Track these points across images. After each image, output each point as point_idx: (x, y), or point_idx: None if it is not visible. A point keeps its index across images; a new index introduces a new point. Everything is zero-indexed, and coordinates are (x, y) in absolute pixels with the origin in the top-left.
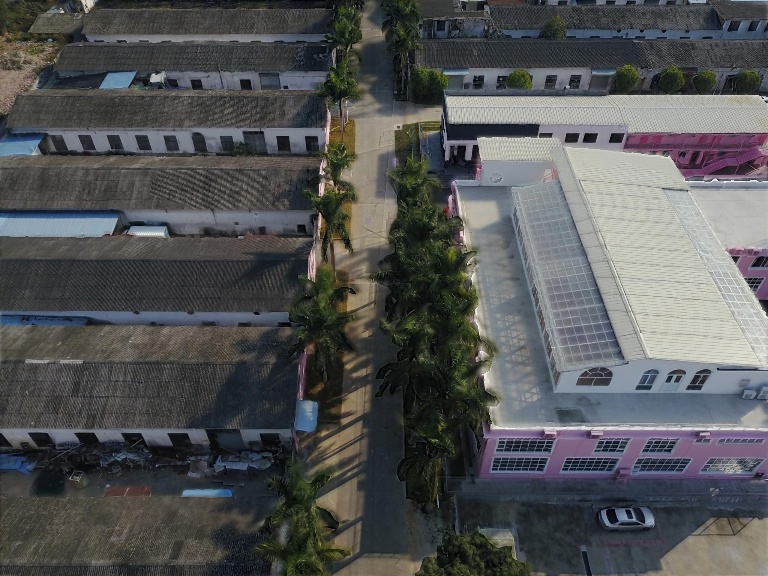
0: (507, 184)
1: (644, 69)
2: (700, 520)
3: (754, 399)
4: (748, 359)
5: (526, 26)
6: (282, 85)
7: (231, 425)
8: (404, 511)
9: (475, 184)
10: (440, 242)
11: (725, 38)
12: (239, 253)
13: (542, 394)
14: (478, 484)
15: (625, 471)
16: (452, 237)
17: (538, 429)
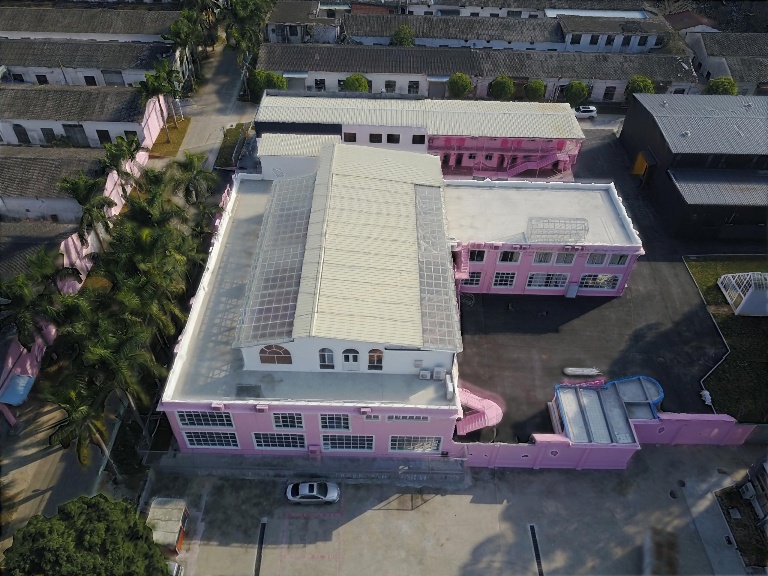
0: None
1: None
2: (385, 496)
3: (430, 379)
4: (412, 340)
5: (376, 34)
6: (126, 83)
7: None
8: (96, 482)
9: (258, 178)
10: (190, 229)
11: None
12: None
13: (231, 371)
14: (178, 458)
15: (314, 447)
16: (206, 225)
17: (207, 402)
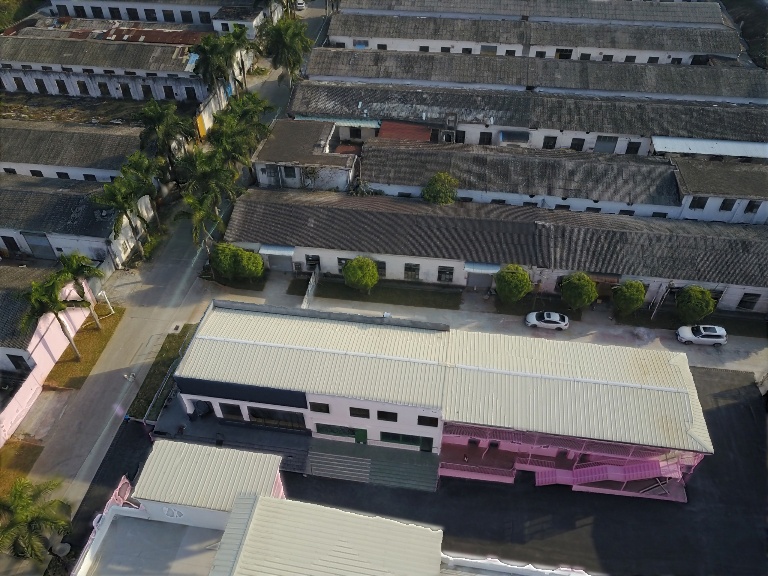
0: (190, 523)
1: (542, 268)
2: None
3: None
4: None
5: (403, 180)
6: (54, 246)
7: None
8: None
9: (142, 516)
10: None
11: (686, 216)
12: None
13: None
14: None
15: None
16: None
17: None
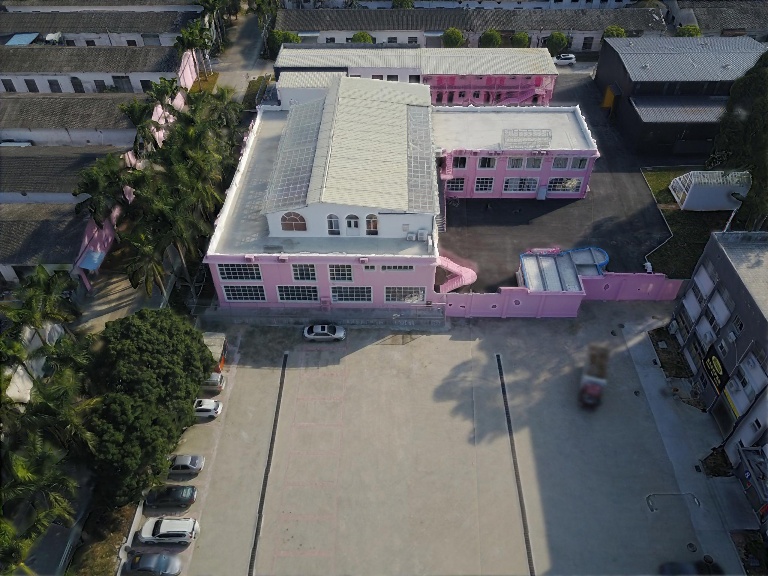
0: None
1: None
2: (381, 336)
3: (416, 241)
4: (400, 205)
5: None
6: (163, 45)
7: (29, 261)
8: None
9: (278, 109)
10: (223, 143)
11: None
12: (70, 153)
13: (259, 237)
14: (218, 311)
15: (325, 299)
16: (236, 141)
17: (241, 255)
